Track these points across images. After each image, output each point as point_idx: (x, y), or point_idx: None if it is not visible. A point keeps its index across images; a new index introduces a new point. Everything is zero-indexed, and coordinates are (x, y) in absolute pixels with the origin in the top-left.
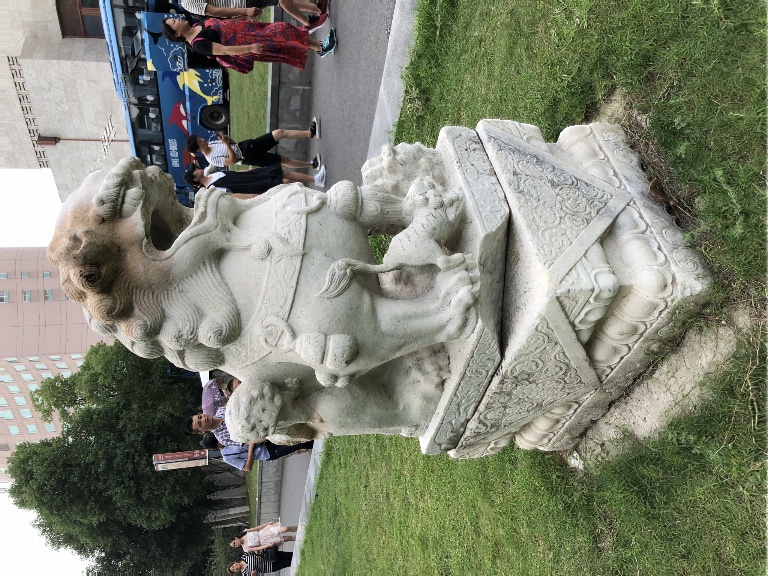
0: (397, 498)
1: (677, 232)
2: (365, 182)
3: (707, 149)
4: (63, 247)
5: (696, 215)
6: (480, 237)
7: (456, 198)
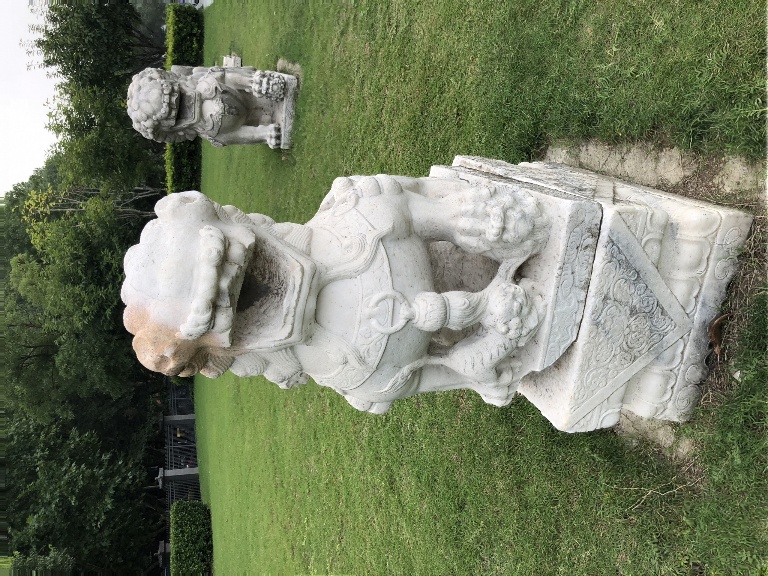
0: (371, 102)
1: (700, 369)
2: (460, 230)
3: (766, 389)
4: (152, 365)
5: (724, 371)
6: (535, 368)
7: (535, 327)
